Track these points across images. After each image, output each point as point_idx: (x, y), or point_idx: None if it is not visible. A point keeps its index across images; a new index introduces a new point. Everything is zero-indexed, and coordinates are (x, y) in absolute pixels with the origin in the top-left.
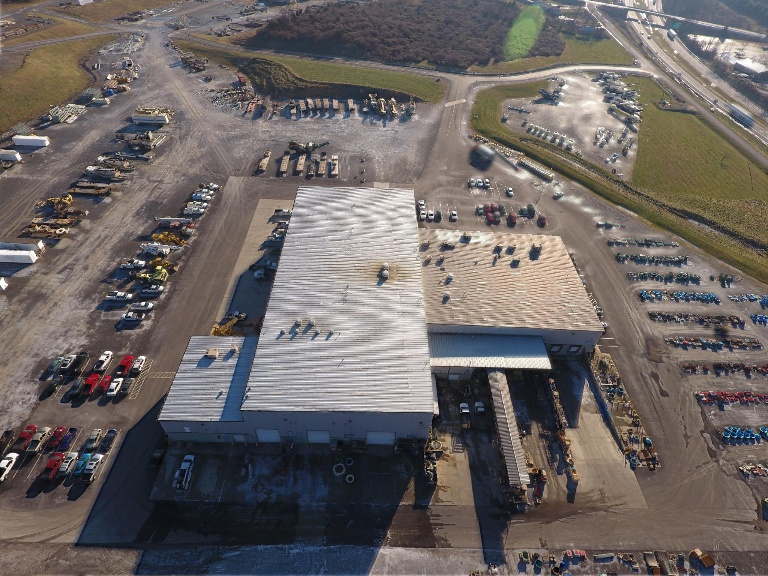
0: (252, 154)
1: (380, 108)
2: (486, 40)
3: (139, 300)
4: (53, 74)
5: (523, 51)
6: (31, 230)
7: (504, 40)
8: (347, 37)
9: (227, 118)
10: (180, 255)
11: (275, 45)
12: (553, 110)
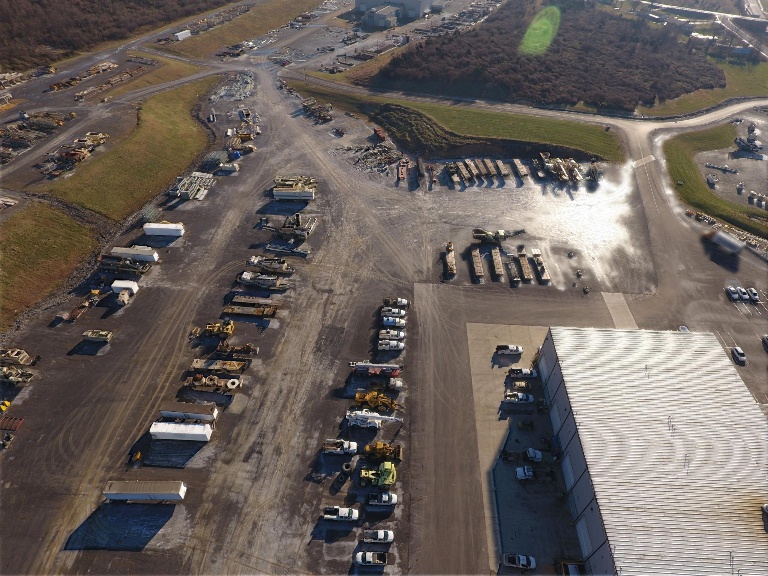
0: (428, 245)
1: (561, 173)
2: (639, 71)
3: (367, 519)
4: (171, 133)
5: (685, 84)
6: (196, 383)
7: (659, 70)
8: (488, 75)
9: (379, 189)
10: (397, 428)
11: (403, 86)
12: (762, 167)
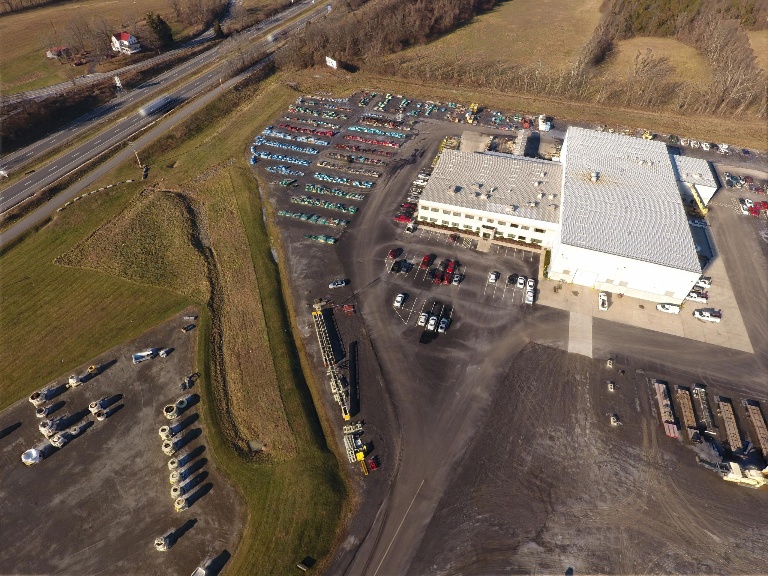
0: None
1: None
2: None
3: None
4: None
5: None
6: None
7: None
8: None
9: None
10: None
11: None
12: None
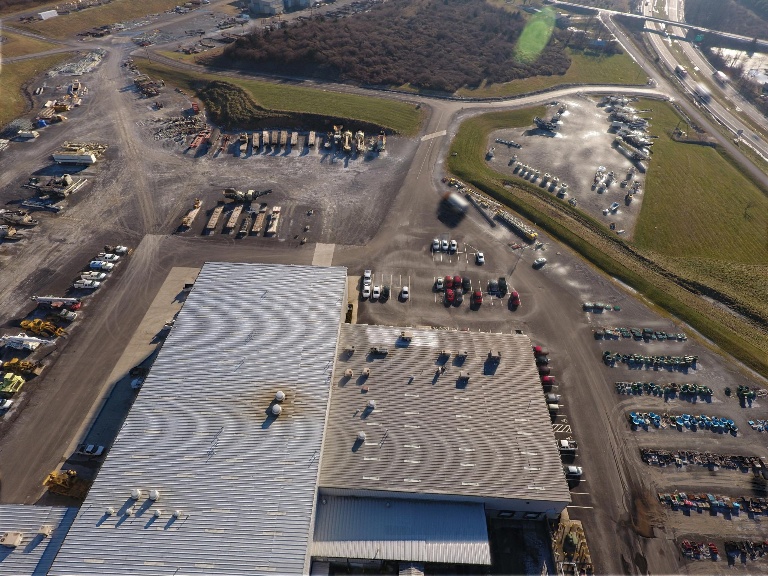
0: (182, 203)
1: (343, 144)
2: (480, 58)
3: None
4: None
5: (521, 70)
6: None
7: (501, 57)
8: (321, 57)
9: (166, 156)
10: (51, 350)
11: (242, 65)
12: (548, 143)
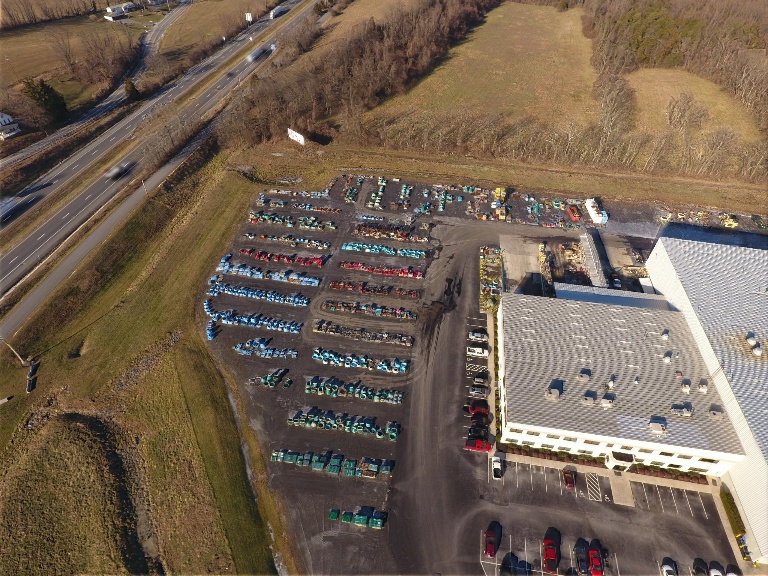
0: None
1: None
2: None
3: None
4: None
5: None
6: None
7: None
8: None
9: None
10: None
11: None
12: None
